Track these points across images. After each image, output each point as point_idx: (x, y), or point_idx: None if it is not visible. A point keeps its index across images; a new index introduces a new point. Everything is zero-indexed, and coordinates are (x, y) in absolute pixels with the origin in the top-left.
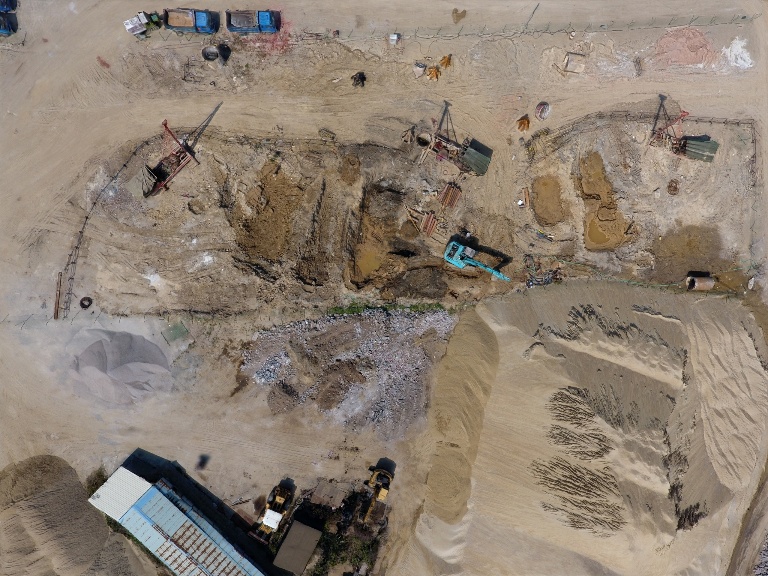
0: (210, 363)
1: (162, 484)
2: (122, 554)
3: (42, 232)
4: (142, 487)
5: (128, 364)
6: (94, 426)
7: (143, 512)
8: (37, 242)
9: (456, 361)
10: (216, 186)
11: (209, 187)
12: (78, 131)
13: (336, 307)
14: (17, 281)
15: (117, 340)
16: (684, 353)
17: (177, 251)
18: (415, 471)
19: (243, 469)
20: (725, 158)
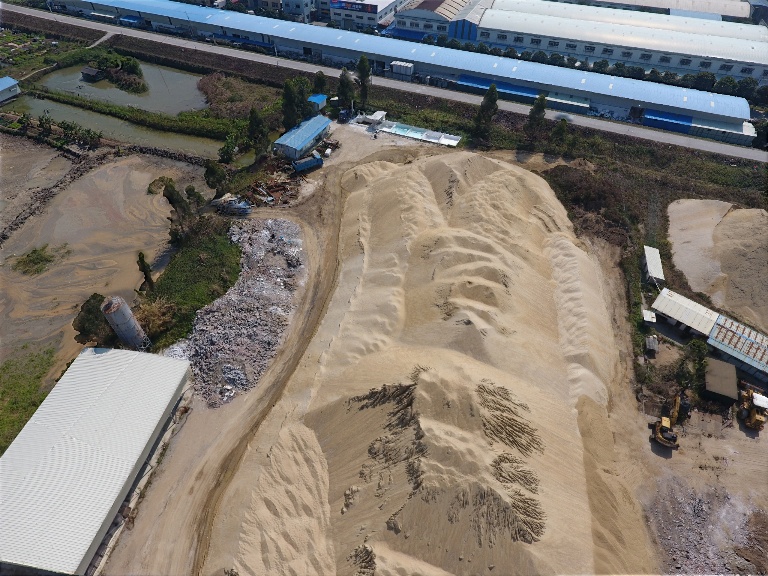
0: None
1: None
2: None
3: None
4: None
5: None
6: None
7: None
8: None
9: None
10: None
11: None
12: None
13: None
14: None
15: None
16: None
17: None
18: (630, 445)
19: None
20: None
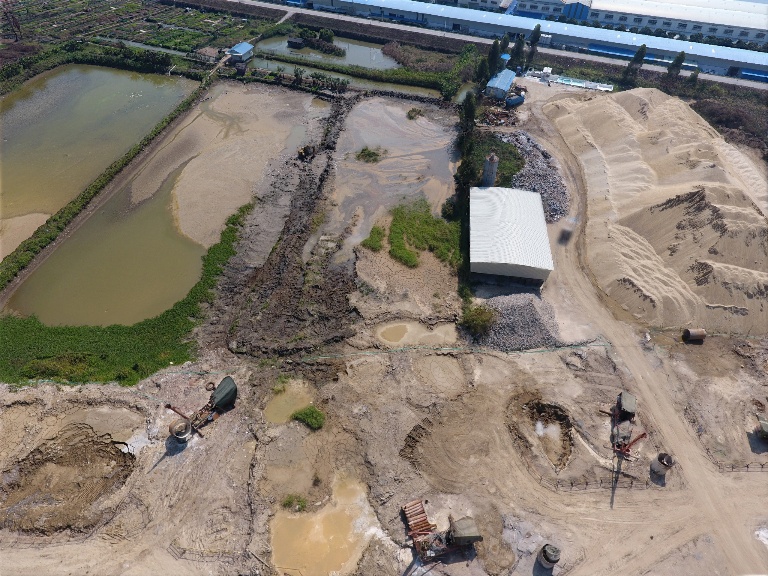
0: None
1: None
2: None
3: None
4: None
5: None
6: None
7: None
8: None
9: None
10: None
11: None
12: None
13: None
14: None
15: None
16: (707, 281)
17: None
18: None
19: None
20: (726, 434)
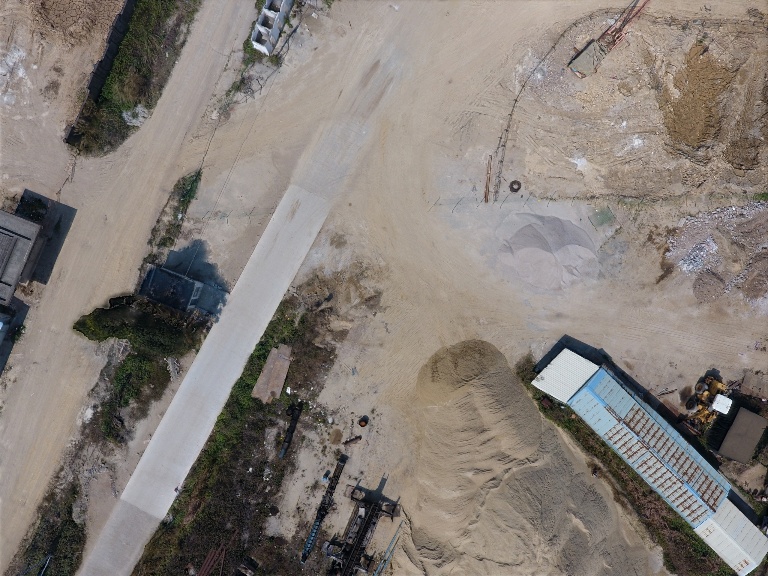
0: (635, 250)
1: (606, 367)
2: (556, 440)
3: (473, 115)
4: (589, 369)
5: (568, 246)
6: (522, 311)
7: (596, 393)
8: (469, 125)
9: None
10: (645, 68)
11: (638, 69)
12: (507, 13)
13: (764, 193)
14: (448, 164)
15: (550, 223)
16: None
17: (606, 134)
18: None
19: (669, 358)
20: None
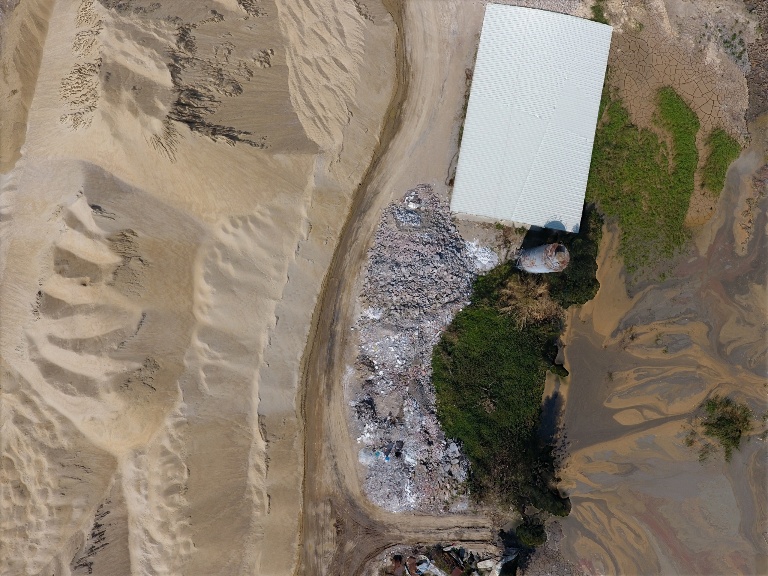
0: None
1: None
2: None
3: None
4: None
5: None
6: None
7: None
8: None
9: (23, 4)
10: None
11: None
12: None
13: None
14: None
15: None
16: None
17: None
18: None
19: None
20: None
